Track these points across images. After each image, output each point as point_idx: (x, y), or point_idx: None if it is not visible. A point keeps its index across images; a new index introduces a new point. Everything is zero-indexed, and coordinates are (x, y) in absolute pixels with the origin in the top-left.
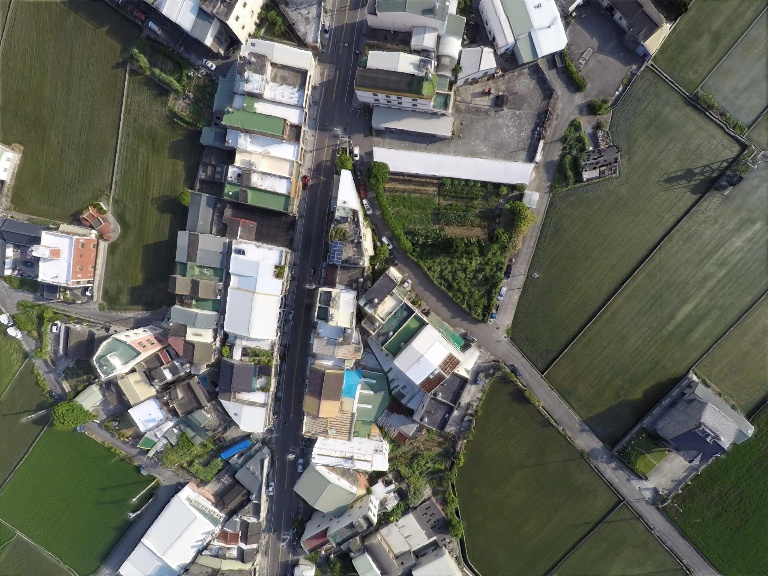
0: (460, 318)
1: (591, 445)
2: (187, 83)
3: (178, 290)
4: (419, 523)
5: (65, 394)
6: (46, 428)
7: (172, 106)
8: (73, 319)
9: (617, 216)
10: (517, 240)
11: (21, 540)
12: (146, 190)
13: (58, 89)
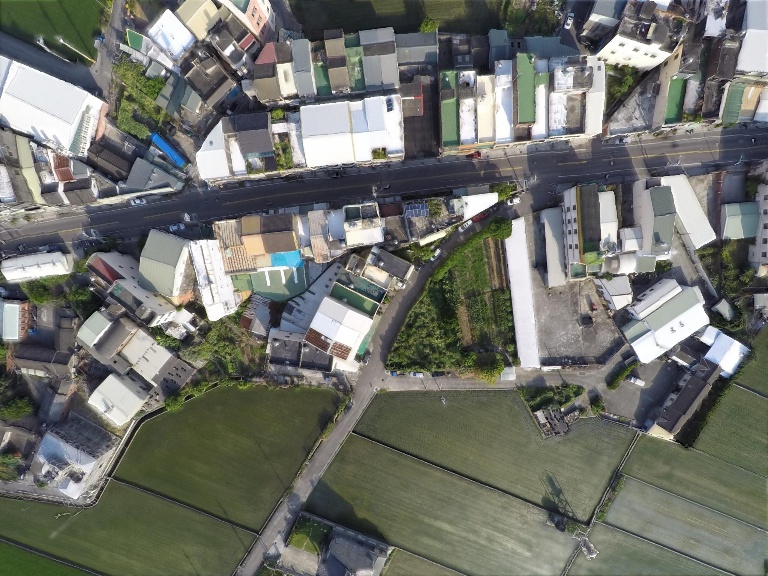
0: (382, 344)
1: (301, 492)
2: None
3: (329, 42)
4: (165, 366)
5: None
6: None
7: None
8: None
9: (510, 448)
10: (468, 373)
11: None
12: None
13: None
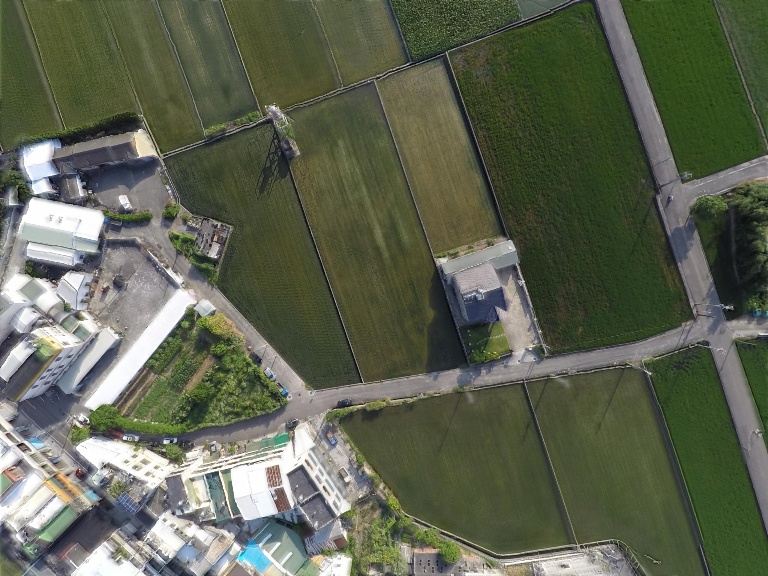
0: (271, 420)
1: (453, 379)
2: None
3: None
4: None
5: None
6: None
7: None
8: None
9: (265, 245)
10: (235, 335)
11: None
12: None
13: None
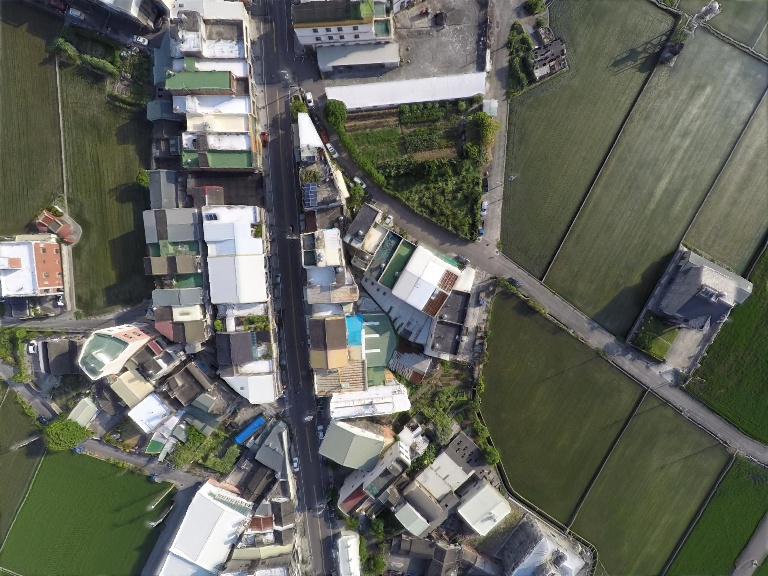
0: (448, 243)
1: (604, 341)
2: (122, 64)
3: (155, 271)
4: (454, 460)
5: (57, 418)
6: (43, 459)
7: (111, 91)
8: (49, 335)
9: (576, 109)
10: (486, 153)
11: None
12: (101, 183)
13: None
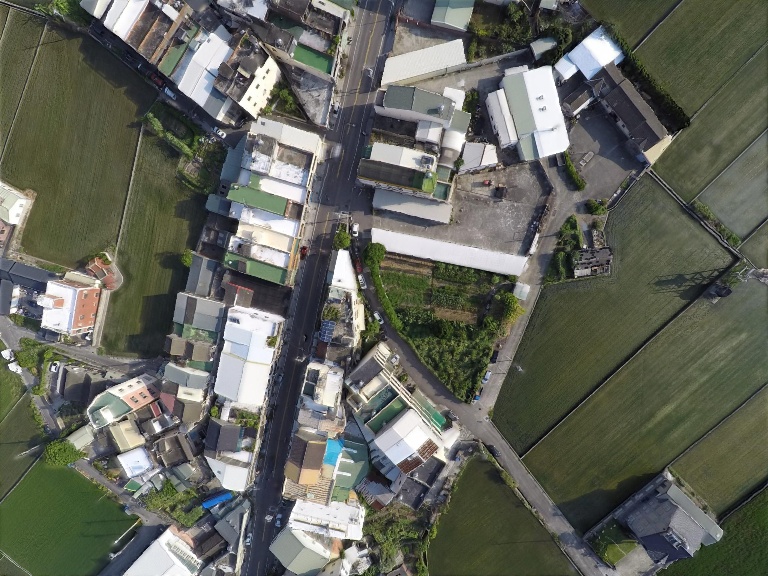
0: (444, 396)
1: (562, 529)
2: (198, 148)
3: (173, 351)
4: None
5: (59, 430)
6: (38, 460)
7: (182, 168)
8: (72, 361)
9: (605, 313)
10: (506, 327)
11: (7, 562)
12: (151, 245)
13: (74, 142)
